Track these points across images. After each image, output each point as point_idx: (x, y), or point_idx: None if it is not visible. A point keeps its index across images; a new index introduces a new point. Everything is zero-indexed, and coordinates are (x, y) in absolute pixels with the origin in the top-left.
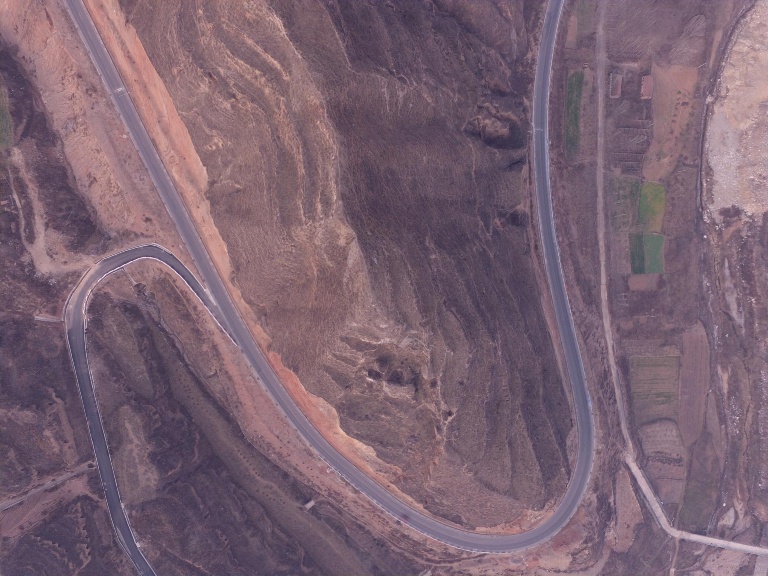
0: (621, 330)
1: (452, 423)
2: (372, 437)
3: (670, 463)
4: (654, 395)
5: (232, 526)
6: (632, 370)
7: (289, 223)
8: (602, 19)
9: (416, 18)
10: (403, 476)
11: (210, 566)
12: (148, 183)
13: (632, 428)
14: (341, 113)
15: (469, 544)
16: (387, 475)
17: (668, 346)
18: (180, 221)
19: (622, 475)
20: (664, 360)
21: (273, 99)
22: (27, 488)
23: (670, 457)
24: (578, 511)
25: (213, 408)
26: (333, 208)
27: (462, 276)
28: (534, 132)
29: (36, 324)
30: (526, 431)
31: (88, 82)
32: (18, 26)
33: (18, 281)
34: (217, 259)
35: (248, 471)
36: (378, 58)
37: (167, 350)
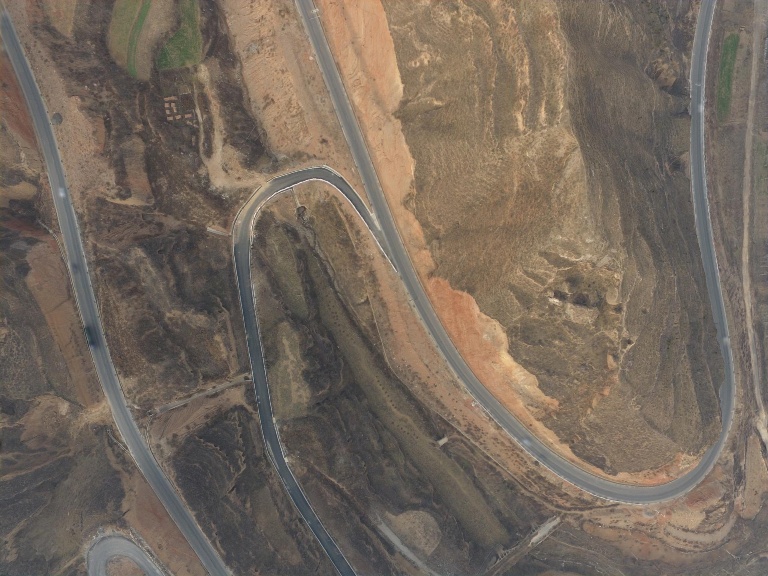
0: (759, 295)
1: (629, 352)
2: (539, 364)
3: None
4: None
5: (370, 454)
6: (767, 336)
7: (502, 134)
8: None
9: None
10: (555, 412)
11: (352, 488)
12: (328, 105)
13: (764, 394)
14: (570, 27)
15: (604, 492)
16: (537, 411)
17: None
18: (355, 145)
19: (753, 440)
20: None
21: (500, 12)
22: (192, 391)
23: None
24: (714, 469)
25: (358, 336)
26: (559, 117)
27: (653, 205)
28: (691, 89)
29: (208, 235)
30: (690, 372)
31: (282, 4)
32: None
33: (195, 192)
34: (390, 183)
35: (385, 402)
36: None
37: (319, 275)
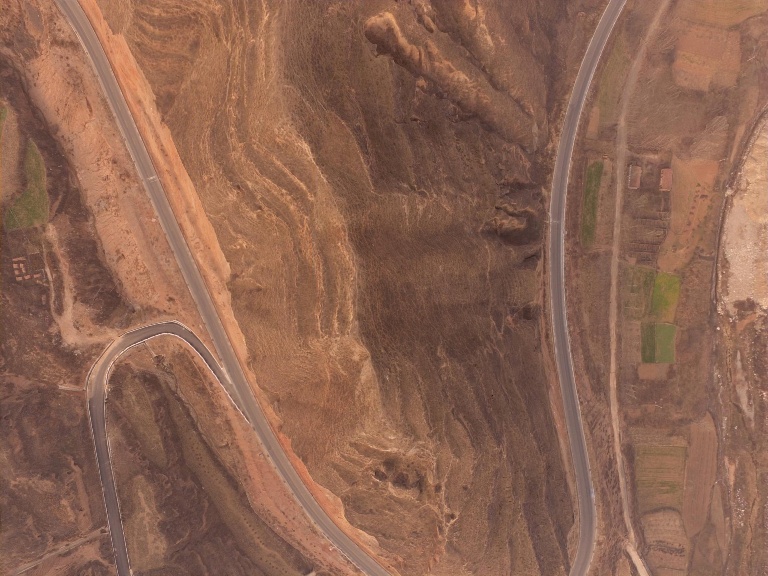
0: (628, 418)
1: (454, 525)
2: (375, 529)
3: (672, 553)
4: (659, 484)
5: None
6: (638, 458)
7: (306, 332)
8: (624, 111)
9: (439, 127)
10: (404, 563)
11: None
12: (173, 265)
13: (635, 516)
14: (362, 235)
15: None
16: (388, 559)
17: (675, 436)
18: (201, 302)
19: (622, 563)
20: (670, 450)
21: (297, 215)
22: (42, 553)
23: (672, 547)
24: None
25: (223, 477)
26: (349, 327)
27: (471, 384)
28: (551, 222)
29: (60, 393)
30: (527, 531)
31: (122, 167)
32: (59, 109)
33: (45, 351)
34: (235, 342)
35: (253, 539)
36: (400, 174)
37: (182, 419)
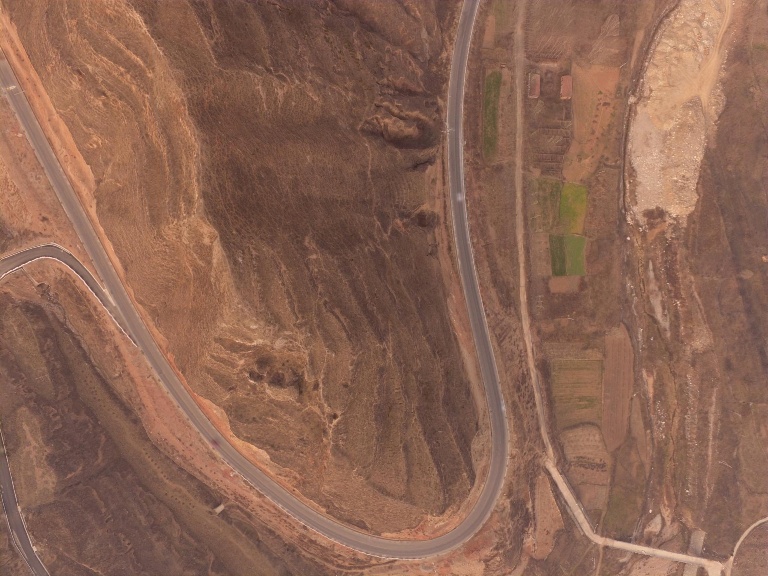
0: (542, 333)
1: (338, 426)
2: (263, 440)
3: (593, 468)
4: (576, 399)
5: (137, 530)
6: (554, 373)
7: (159, 222)
8: (520, 19)
9: (304, 16)
10: (302, 480)
11: (109, 571)
12: (44, 182)
13: (553, 432)
14: (205, 110)
15: (378, 550)
16: (288, 479)
17: (590, 349)
18: (77, 221)
19: (542, 480)
20: (586, 363)
21: (140, 96)
22: None
23: (593, 462)
24: (491, 517)
25: (120, 410)
26: (195, 207)
27: (346, 277)
28: (448, 132)
29: None
30: (422, 435)
31: None
32: None
33: None
34: (113, 259)
35: (156, 474)
36: (254, 56)
37: (72, 351)
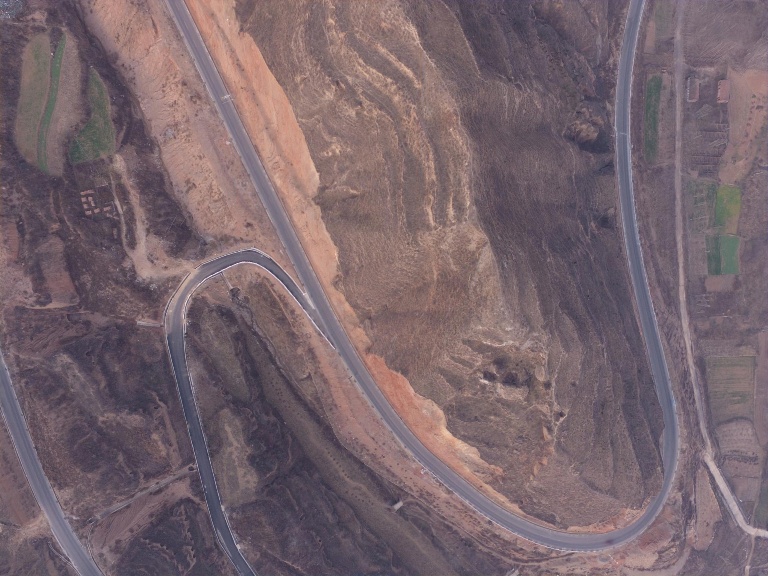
0: (698, 331)
1: (563, 424)
2: (478, 438)
3: (746, 462)
4: (730, 394)
5: (325, 527)
6: (709, 370)
7: (415, 228)
8: (679, 24)
9: (523, 25)
10: (501, 476)
11: (308, 567)
12: (250, 189)
13: (710, 427)
14: (472, 120)
15: (558, 543)
16: (484, 476)
17: (744, 346)
18: (281, 226)
19: (701, 474)
20: (740, 360)
21: (402, 107)
22: (134, 491)
23: (746, 456)
24: (663, 510)
25: (304, 411)
26: (466, 213)
27: (574, 279)
28: (617, 136)
29: (138, 329)
30: (627, 431)
31: (192, 89)
32: (120, 34)
33: (121, 286)
34: (319, 263)
35: (338, 473)
36: (497, 65)
37: (260, 353)
